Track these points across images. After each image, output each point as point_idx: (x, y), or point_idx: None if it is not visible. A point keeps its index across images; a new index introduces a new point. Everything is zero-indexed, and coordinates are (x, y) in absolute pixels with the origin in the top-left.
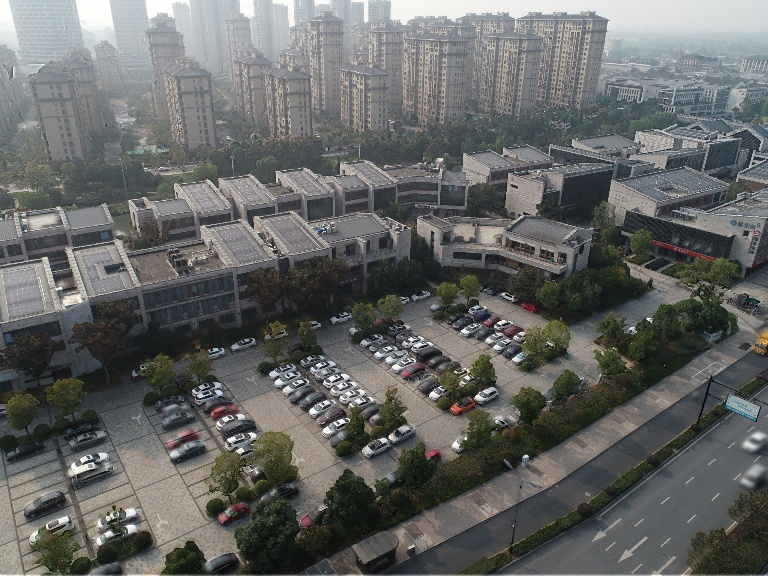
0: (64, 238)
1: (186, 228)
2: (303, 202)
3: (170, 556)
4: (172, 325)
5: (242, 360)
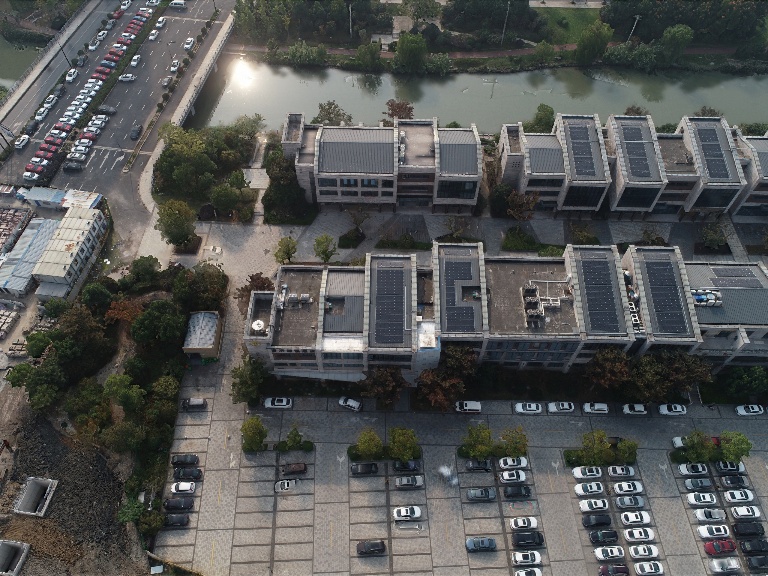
0: (432, 176)
1: (551, 188)
2: (698, 188)
3: None
4: (503, 361)
5: (554, 429)
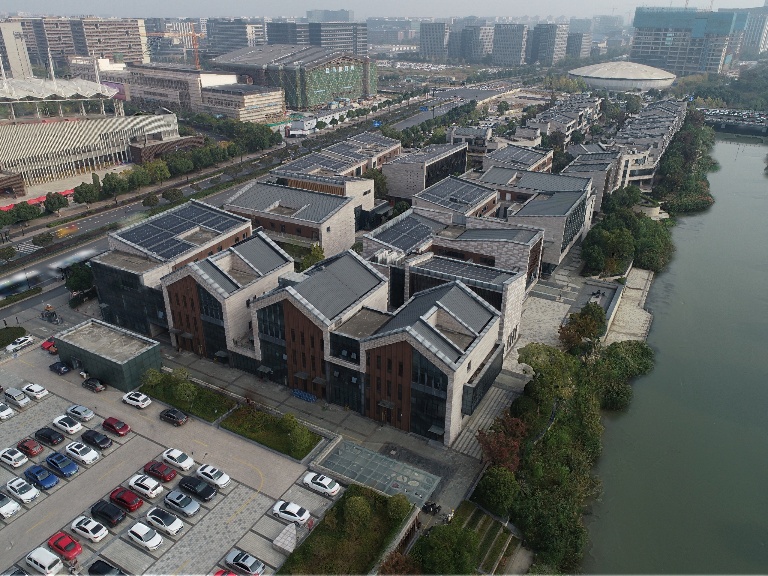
0: None
1: None
2: None
3: None
4: None
5: None
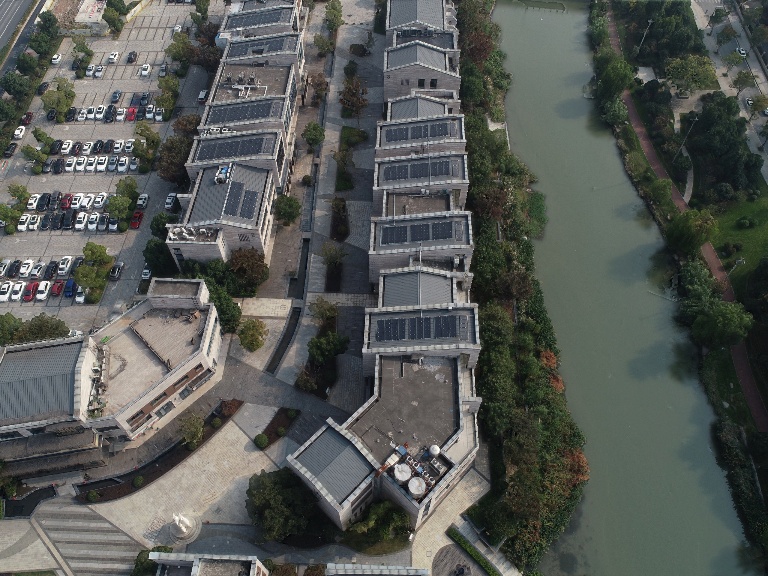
0: None
1: None
2: None
3: (31, 56)
4: None
5: None
